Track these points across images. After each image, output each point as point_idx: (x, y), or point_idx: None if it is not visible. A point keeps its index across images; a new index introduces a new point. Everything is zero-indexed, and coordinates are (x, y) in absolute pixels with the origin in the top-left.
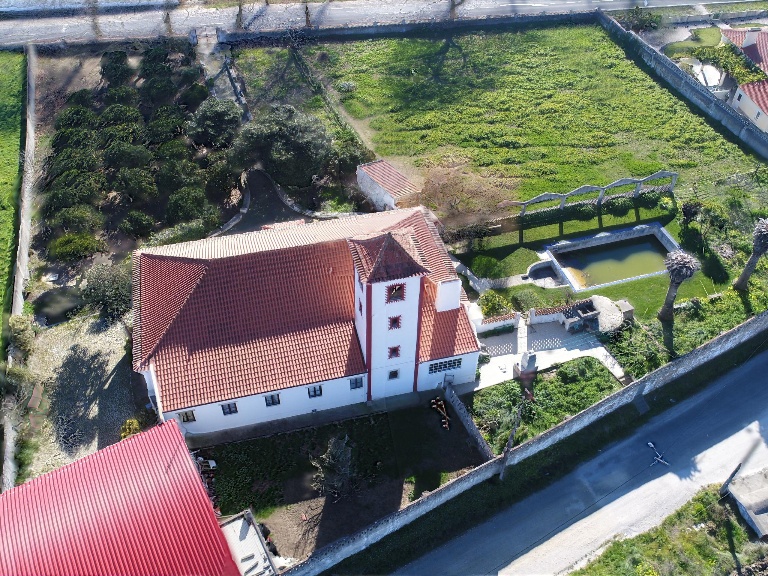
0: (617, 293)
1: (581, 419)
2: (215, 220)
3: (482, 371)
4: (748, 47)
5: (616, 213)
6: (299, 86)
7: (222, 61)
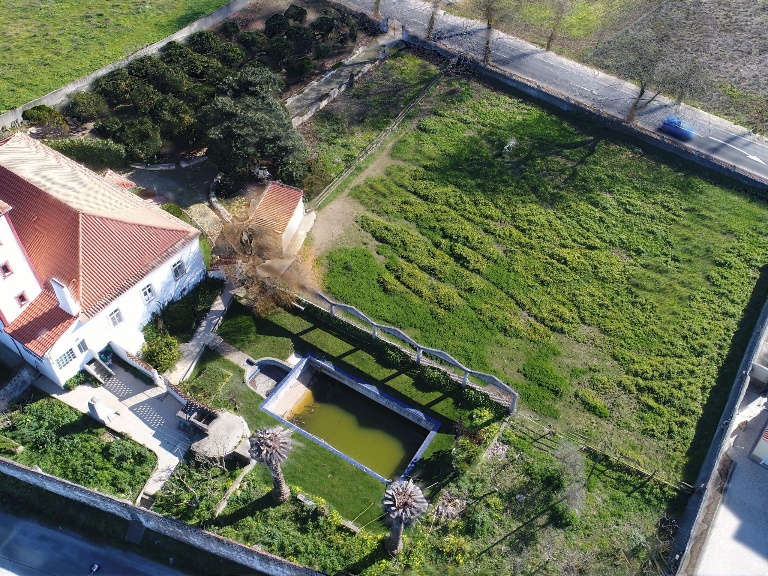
0: None
1: None
2: (140, 155)
3: (80, 388)
4: None
5: (419, 383)
6: (396, 104)
7: None
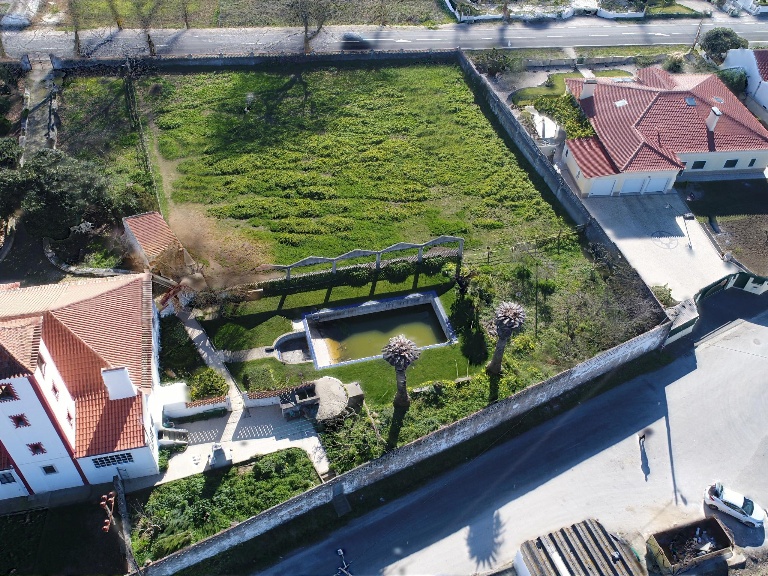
0: (361, 372)
1: (254, 525)
2: None
3: (172, 462)
4: (585, 99)
5: (393, 279)
6: (120, 121)
7: (50, 90)
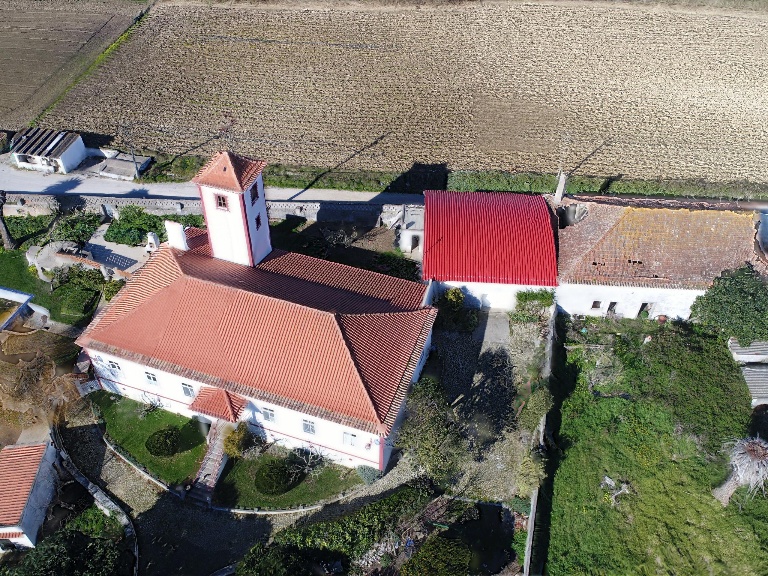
0: (10, 279)
1: None
2: None
3: None
4: None
5: None
6: None
7: None
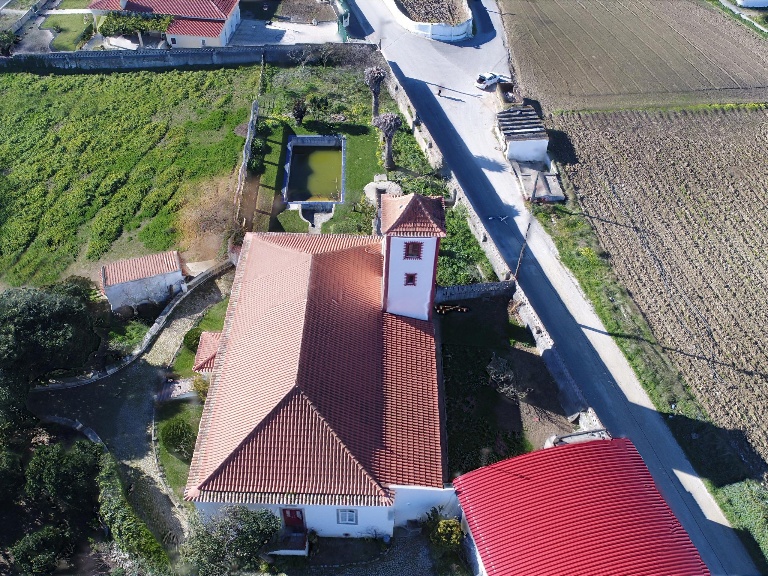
0: (355, 182)
1: None
2: (102, 446)
3: None
4: (127, 6)
5: (266, 152)
6: None
7: None
